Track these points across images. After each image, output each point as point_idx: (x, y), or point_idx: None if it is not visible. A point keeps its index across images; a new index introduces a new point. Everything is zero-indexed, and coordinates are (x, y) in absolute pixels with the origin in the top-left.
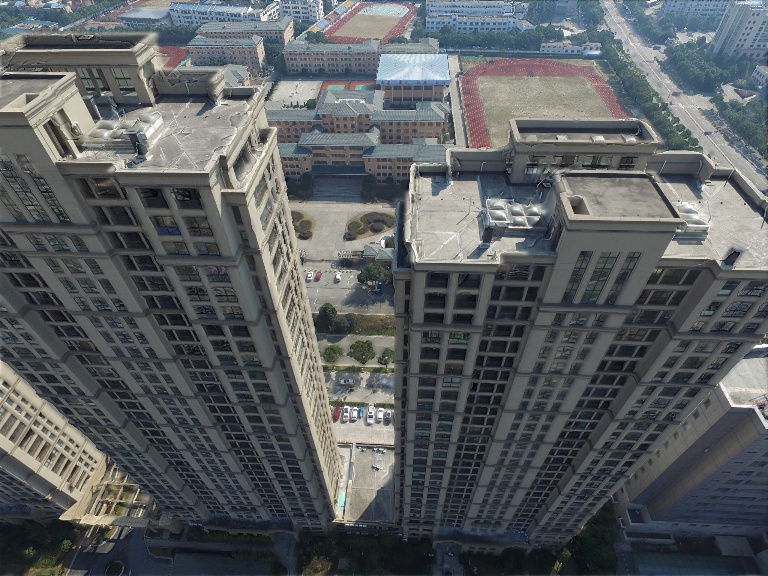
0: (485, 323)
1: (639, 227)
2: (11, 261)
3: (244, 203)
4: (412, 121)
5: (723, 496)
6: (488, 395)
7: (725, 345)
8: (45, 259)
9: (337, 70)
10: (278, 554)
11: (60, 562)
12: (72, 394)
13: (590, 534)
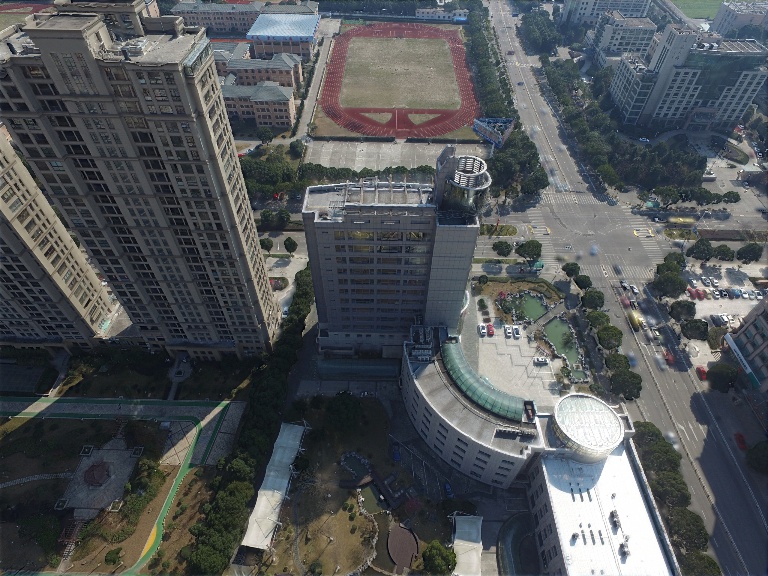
0: (48, 115)
1: (66, 35)
2: None
3: None
4: (264, 69)
5: (350, 299)
6: (98, 183)
7: (180, 125)
8: None
9: (224, 29)
10: (55, 364)
11: None
12: None
13: (279, 339)
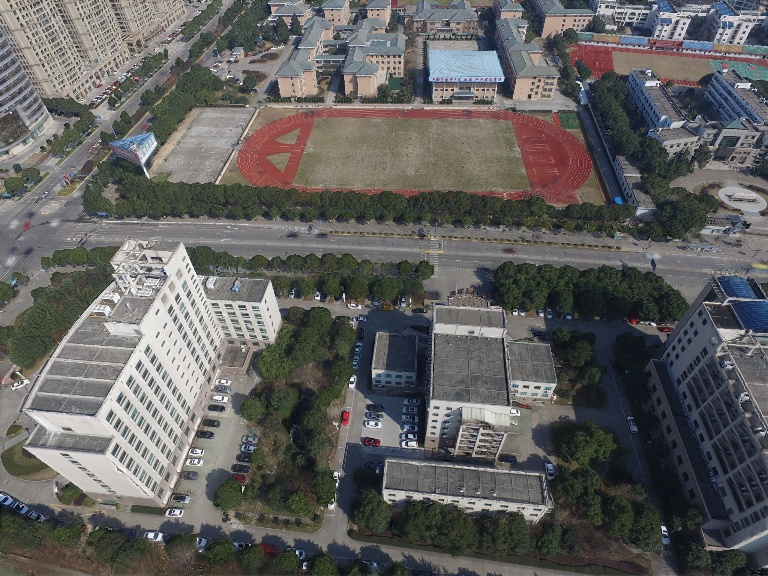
0: None
1: None
2: None
3: None
4: None
5: None
6: None
7: None
8: None
9: None
10: None
11: None
12: None
13: None
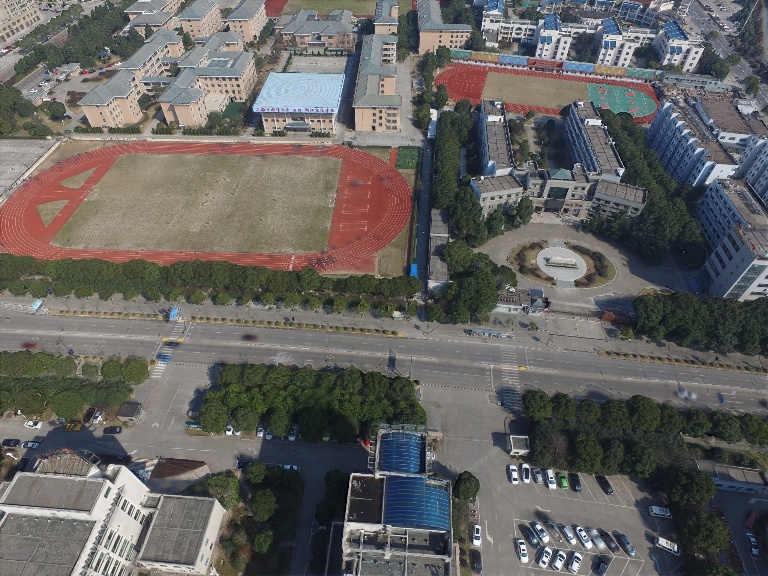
0: None
1: None
2: None
3: None
4: None
5: None
6: None
7: None
8: None
9: None
10: None
11: None
12: None
13: None
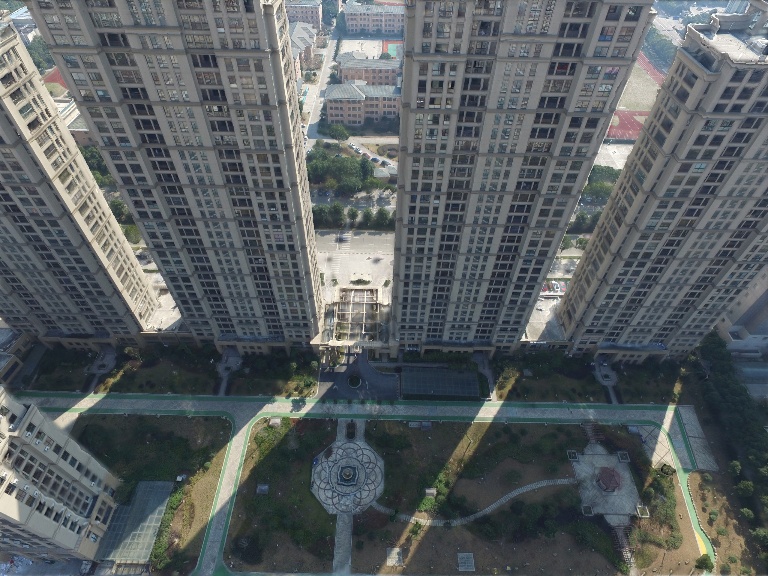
0: None
1: None
2: (477, 68)
3: (651, 21)
4: None
5: None
6: (710, 185)
7: None
8: (506, 64)
9: (393, 31)
10: None
11: (310, 378)
12: (431, 191)
13: (709, 342)
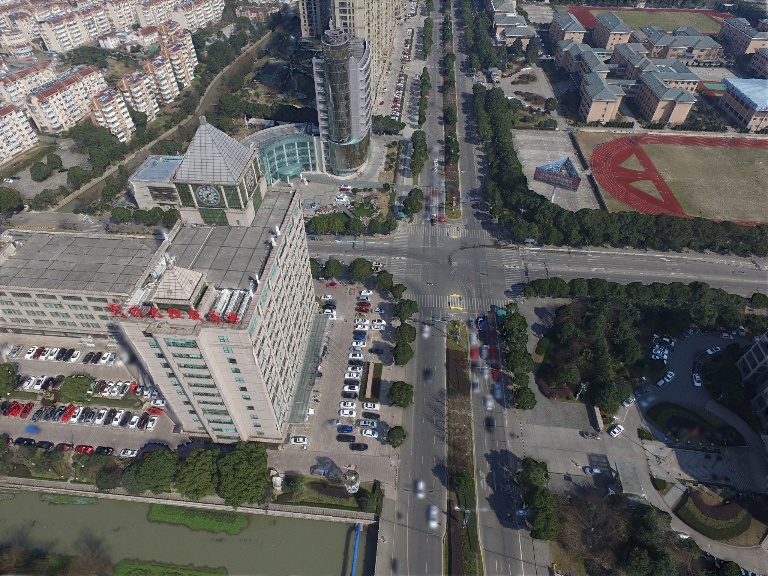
0: None
1: None
2: None
3: None
4: (651, 88)
5: None
6: None
7: None
8: None
9: None
10: None
11: None
12: None
13: None
